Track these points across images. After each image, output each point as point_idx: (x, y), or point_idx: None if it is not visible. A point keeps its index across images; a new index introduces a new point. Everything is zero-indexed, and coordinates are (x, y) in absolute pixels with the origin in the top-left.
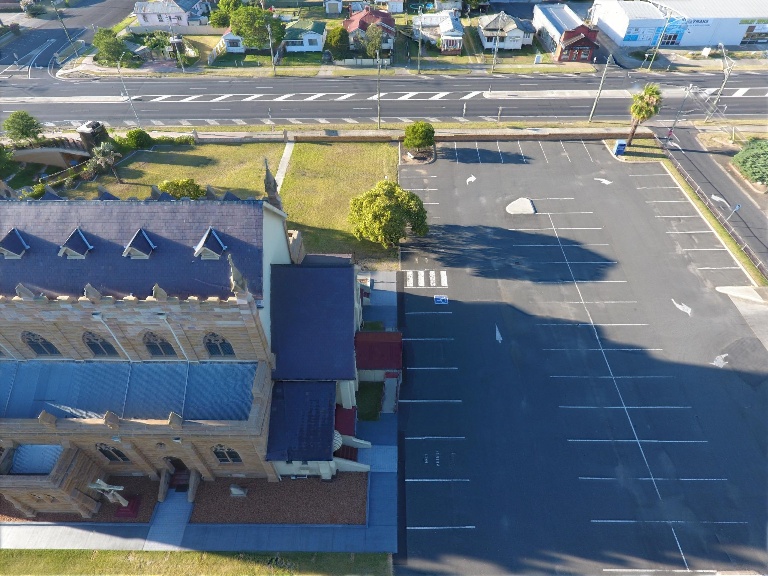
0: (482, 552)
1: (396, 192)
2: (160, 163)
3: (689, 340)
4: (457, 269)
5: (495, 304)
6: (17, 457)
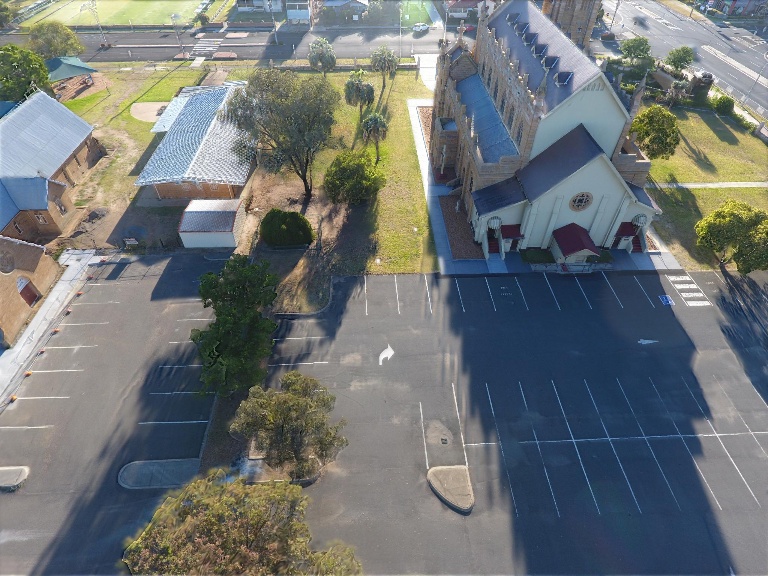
0: (450, 314)
1: (766, 220)
2: (707, 124)
3: (762, 555)
4: (721, 314)
5: (689, 342)
6: (449, 124)
